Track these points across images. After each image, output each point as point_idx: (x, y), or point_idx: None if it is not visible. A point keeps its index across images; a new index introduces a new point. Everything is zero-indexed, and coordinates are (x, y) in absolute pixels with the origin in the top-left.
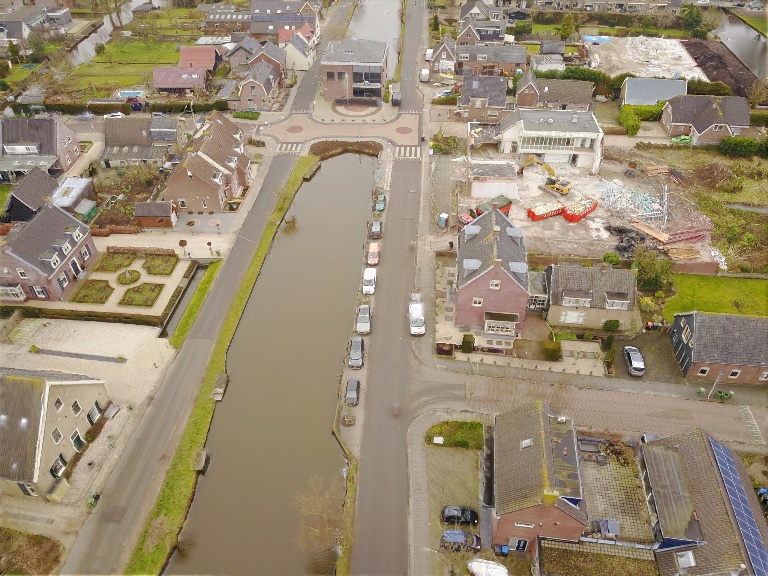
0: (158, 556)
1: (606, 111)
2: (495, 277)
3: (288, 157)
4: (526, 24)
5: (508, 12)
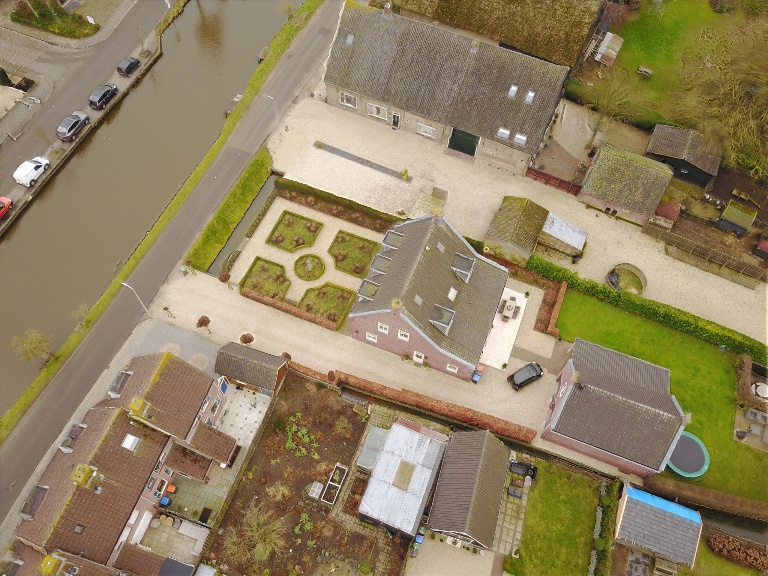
0: (300, 8)
1: None
2: None
3: None
4: None
5: None
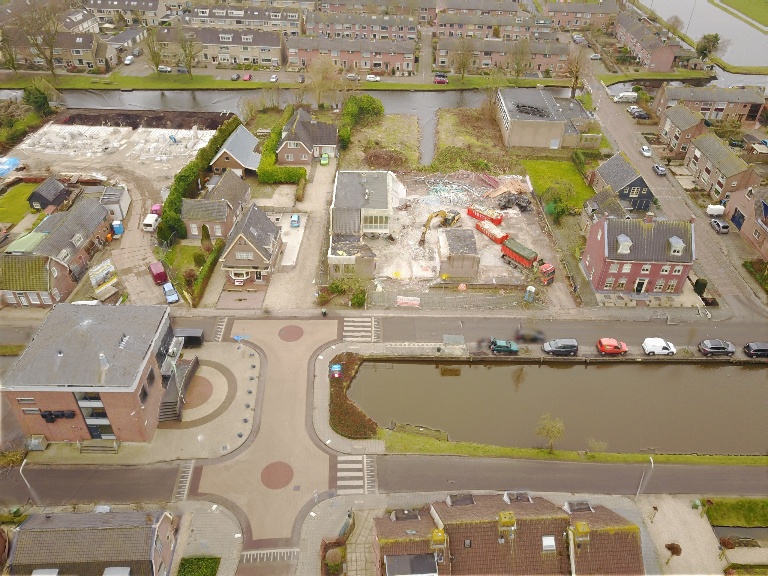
0: None
1: None
2: None
3: (389, 469)
4: None
5: None
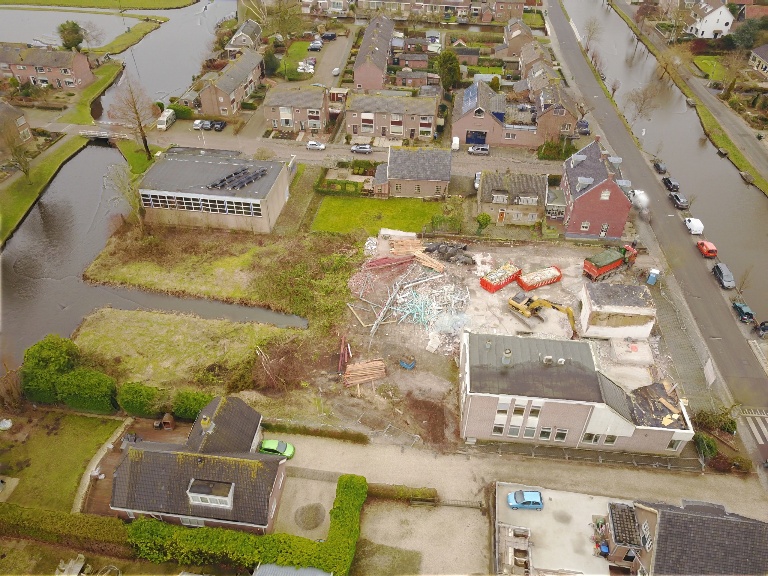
0: None
1: None
2: None
3: None
4: None
5: None
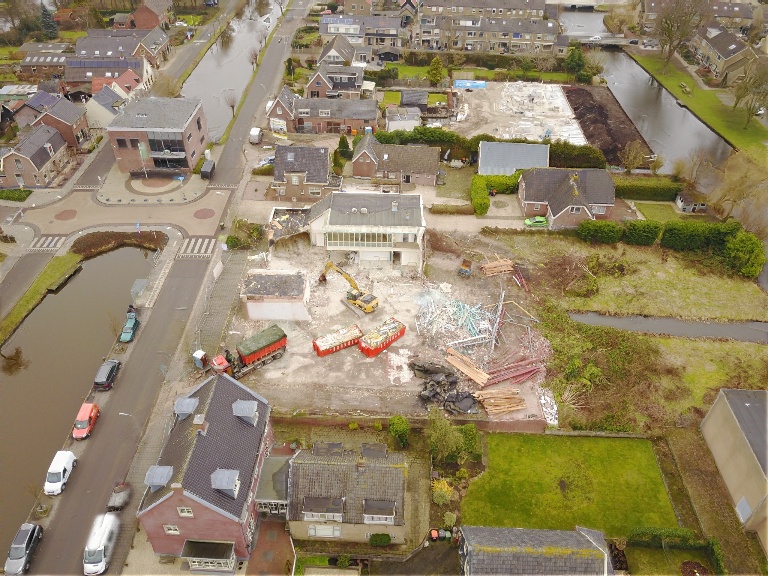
0: None
1: (459, 180)
2: (181, 504)
3: (39, 258)
4: (391, 68)
5: (377, 52)
